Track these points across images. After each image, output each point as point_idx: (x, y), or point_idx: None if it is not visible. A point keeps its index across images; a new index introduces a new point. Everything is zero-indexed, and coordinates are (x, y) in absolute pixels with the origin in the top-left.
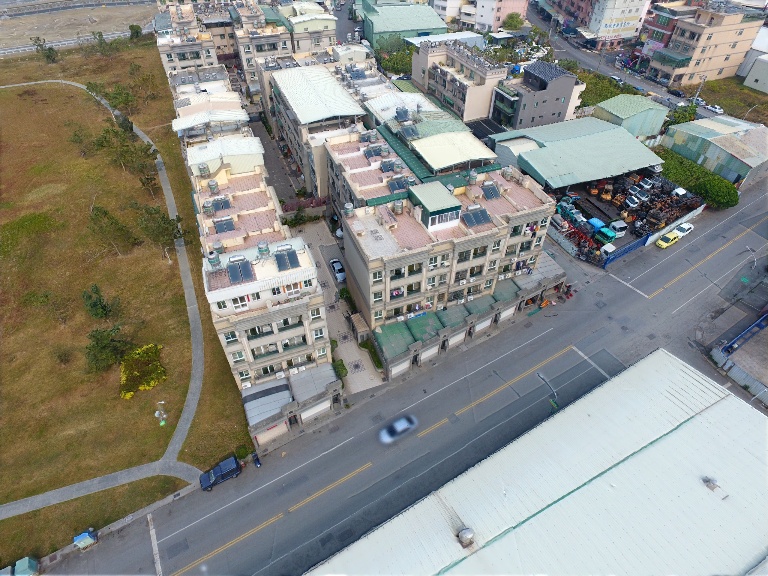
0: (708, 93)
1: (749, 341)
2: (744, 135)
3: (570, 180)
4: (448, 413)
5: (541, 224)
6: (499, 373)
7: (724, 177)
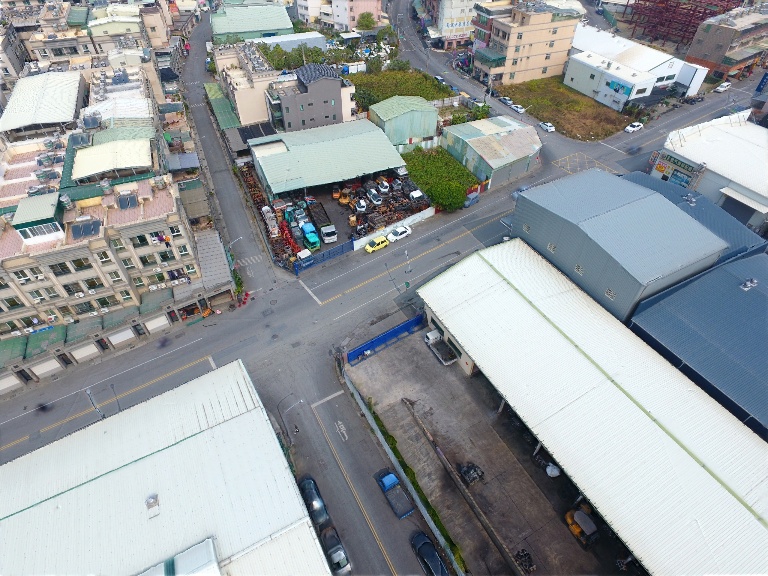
0: (524, 92)
1: (390, 347)
2: (505, 136)
3: (295, 185)
4: (33, 430)
5: (172, 234)
6: (115, 387)
7: (479, 178)
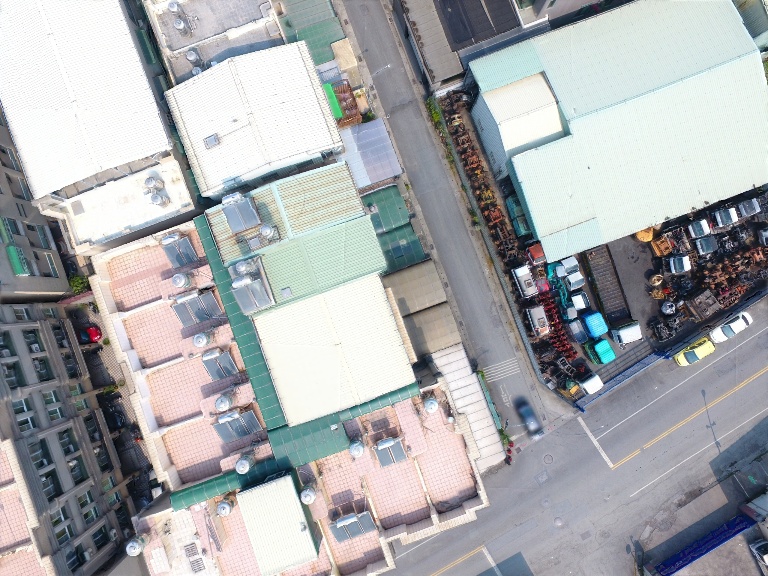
0: None
1: (703, 548)
2: None
3: (584, 240)
4: None
5: None
6: None
7: None
